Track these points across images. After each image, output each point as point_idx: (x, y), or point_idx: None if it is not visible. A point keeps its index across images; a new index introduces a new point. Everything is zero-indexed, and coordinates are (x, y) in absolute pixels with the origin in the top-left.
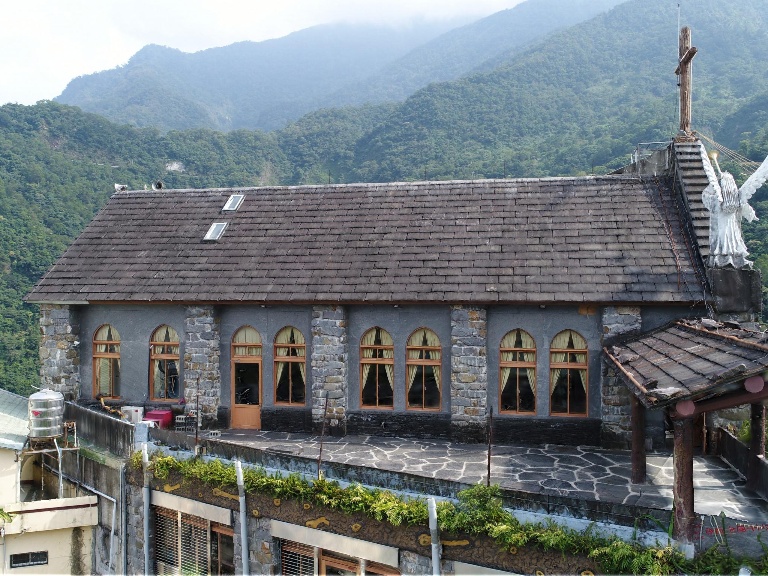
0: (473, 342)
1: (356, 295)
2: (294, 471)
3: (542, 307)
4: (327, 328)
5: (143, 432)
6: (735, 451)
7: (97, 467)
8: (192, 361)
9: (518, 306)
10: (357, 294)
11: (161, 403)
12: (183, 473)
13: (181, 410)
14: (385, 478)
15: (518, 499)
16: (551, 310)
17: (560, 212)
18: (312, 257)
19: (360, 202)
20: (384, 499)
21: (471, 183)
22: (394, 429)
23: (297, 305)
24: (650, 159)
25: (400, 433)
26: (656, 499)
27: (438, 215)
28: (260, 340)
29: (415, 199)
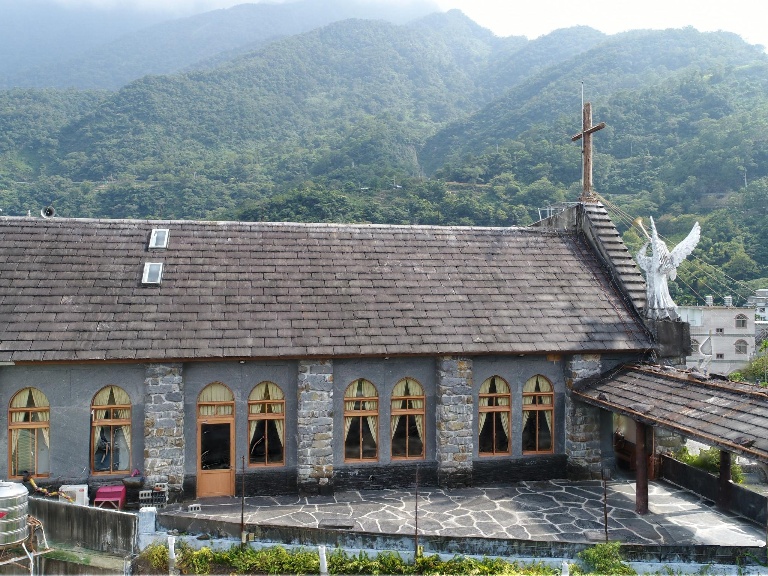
0: (462, 391)
1: (350, 348)
2: (381, 549)
3: (521, 356)
4: (316, 383)
5: (149, 521)
6: (686, 475)
7: (73, 569)
8: (155, 427)
9: (499, 355)
10: (350, 347)
11: (109, 477)
12: (238, 566)
13: (139, 484)
14: (492, 546)
15: (633, 552)
16: (524, 358)
17: (504, 262)
18: (282, 306)
19: (307, 244)
20: (507, 569)
21: (411, 228)
22: (382, 481)
23: (280, 359)
24: (562, 215)
25: (388, 485)
26: (679, 529)
27: (394, 261)
28: (230, 397)
29: (363, 243)
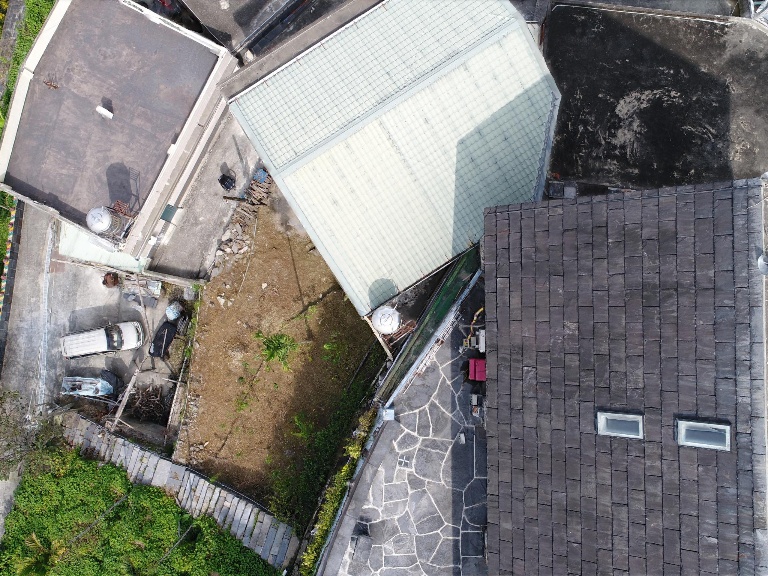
0: None
1: None
2: None
3: None
4: None
5: None
6: None
7: None
8: None
9: None
10: None
11: None
12: None
13: None
14: None
15: None
16: None
17: None
18: None
19: None
20: None
21: None
22: None
23: None
24: None
25: None
26: None
27: None
28: None
29: None
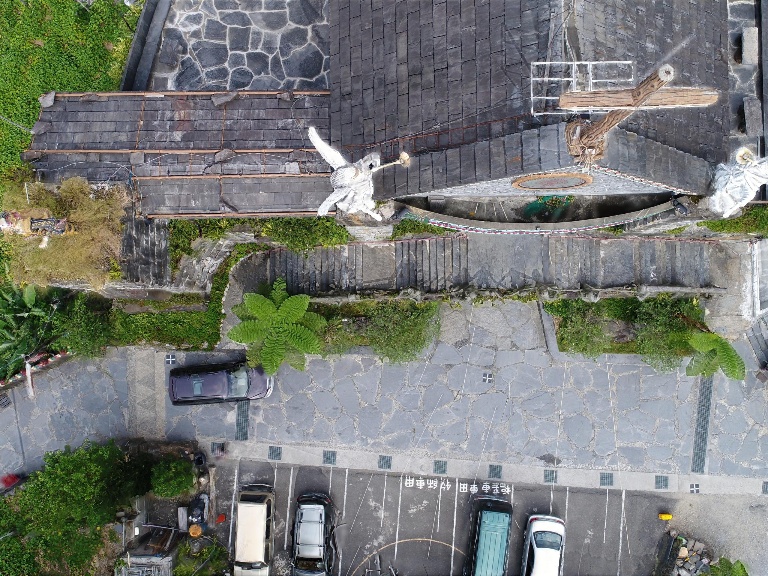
0: None
1: None
2: None
3: None
4: None
5: None
6: None
7: None
8: None
9: None
10: None
11: None
12: None
13: None
14: None
15: None
16: None
17: None
18: None
19: None
20: None
21: None
22: None
23: None
24: None
25: None
26: None
27: None
28: None
29: None
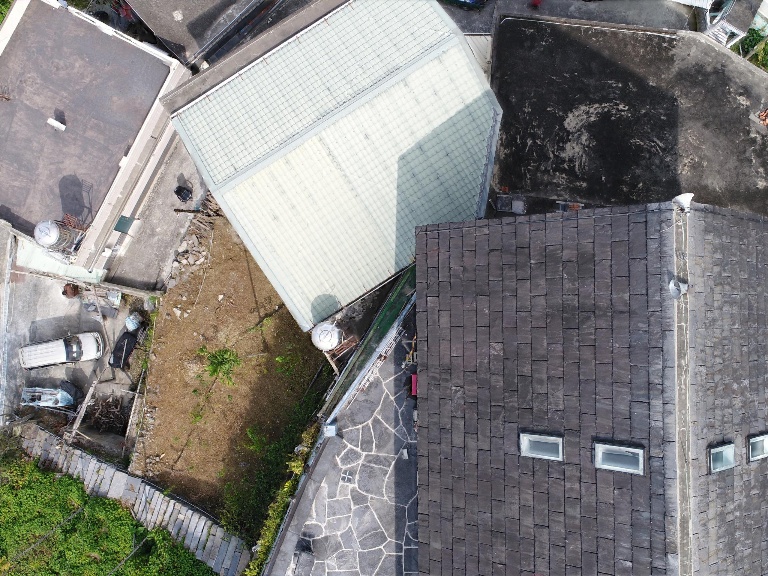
0: None
1: None
2: None
3: None
4: None
5: None
6: None
7: None
8: None
9: None
10: None
11: None
12: (278, 491)
13: None
14: None
15: None
16: None
17: None
18: None
19: None
20: None
21: None
22: None
23: None
24: None
25: None
26: None
27: None
28: None
29: None
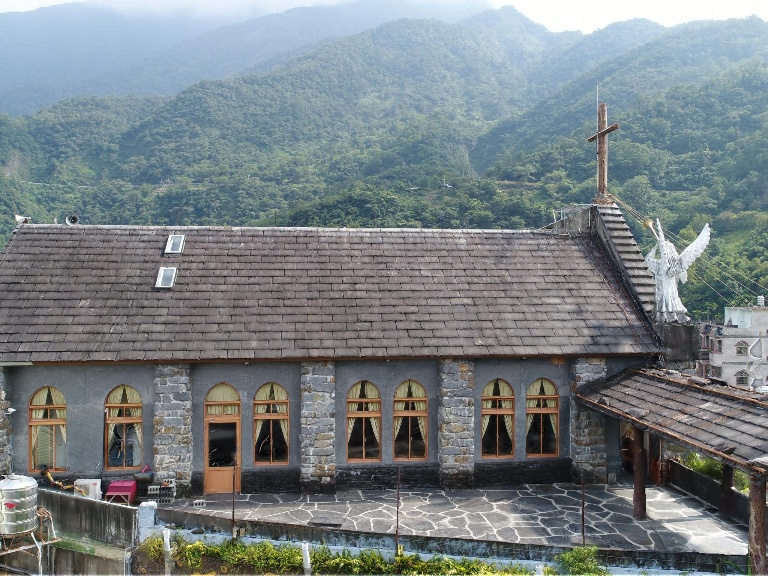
0: (463, 393)
1: (351, 351)
2: (363, 547)
3: (523, 359)
4: (318, 384)
5: (149, 515)
6: (692, 481)
7: (80, 558)
8: (164, 425)
9: (501, 358)
10: (351, 350)
11: (121, 473)
12: (228, 560)
13: (149, 479)
14: (471, 547)
15: (611, 557)
16: (528, 361)
17: (513, 265)
18: (288, 309)
19: (317, 248)
20: (483, 570)
21: (421, 232)
22: (384, 481)
23: (284, 361)
24: (575, 217)
25: (390, 485)
26: (673, 535)
27: (401, 265)
28: (236, 397)
29: (372, 247)
